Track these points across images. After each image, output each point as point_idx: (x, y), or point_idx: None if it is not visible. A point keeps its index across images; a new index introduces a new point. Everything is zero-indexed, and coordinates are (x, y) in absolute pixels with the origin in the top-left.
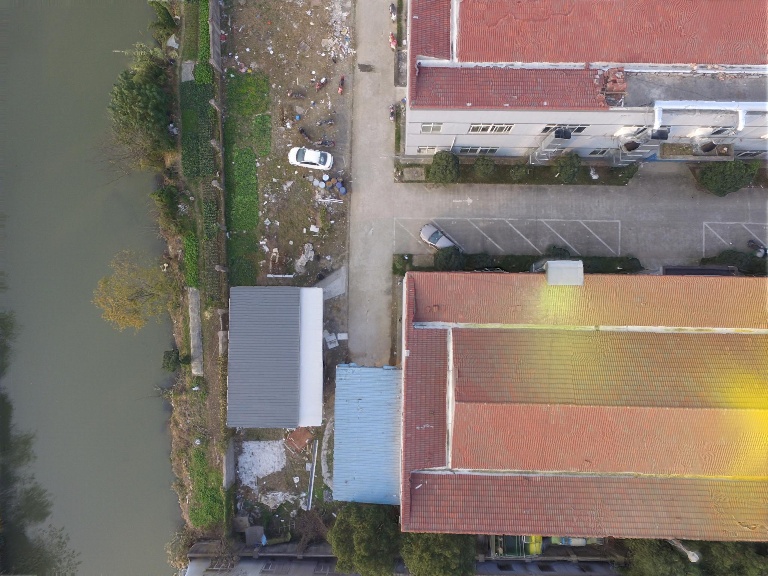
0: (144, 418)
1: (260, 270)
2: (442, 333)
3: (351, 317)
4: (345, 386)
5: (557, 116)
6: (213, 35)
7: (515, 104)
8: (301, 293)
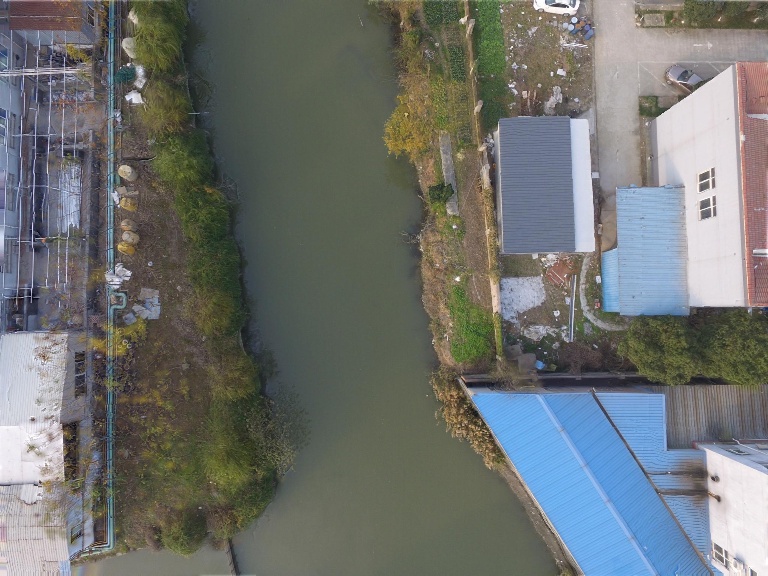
0: None
1: (510, 112)
2: (767, 124)
3: (601, 157)
4: (627, 206)
5: None
6: None
7: None
8: (570, 123)
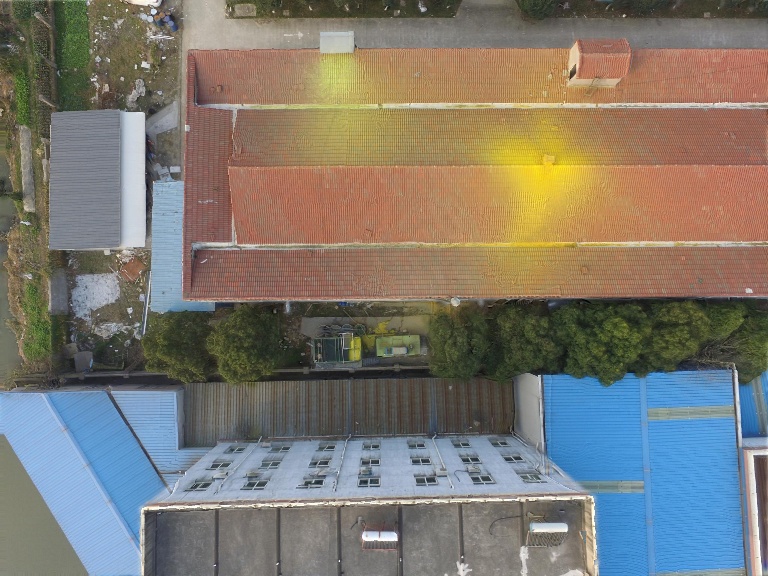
0: None
1: (91, 106)
2: (227, 113)
3: (183, 150)
4: (162, 200)
5: None
6: None
7: None
8: (122, 117)
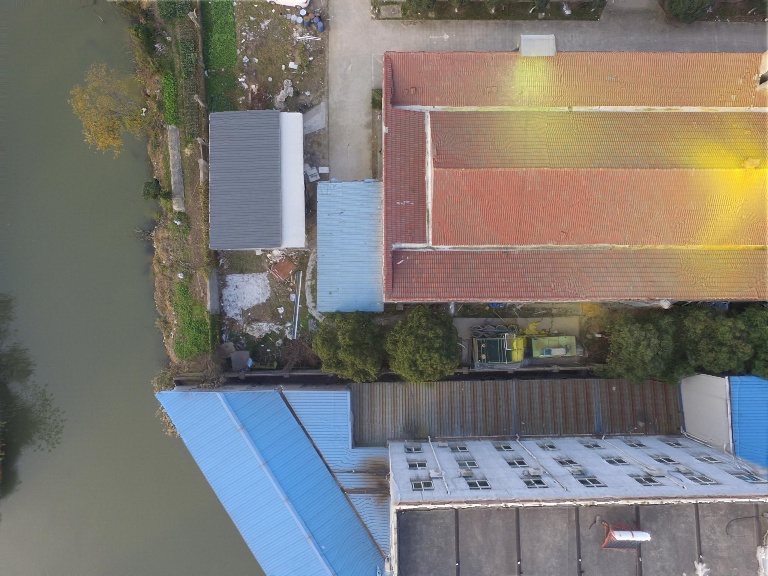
0: (126, 260)
1: (239, 107)
2: (420, 115)
3: (332, 151)
4: (327, 201)
5: None
6: None
7: None
8: (281, 117)
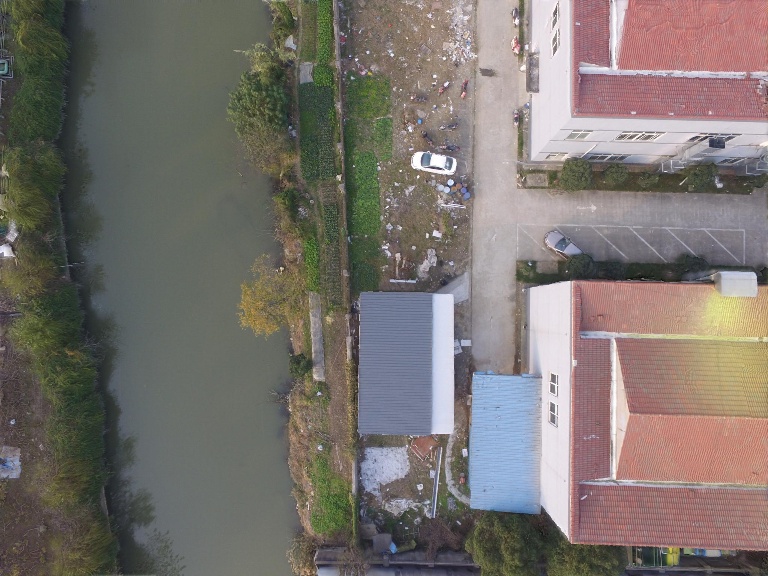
0: (260, 423)
1: (382, 275)
2: (606, 343)
3: (474, 323)
4: (482, 394)
5: (716, 125)
6: (337, 37)
7: (682, 113)
8: (433, 299)
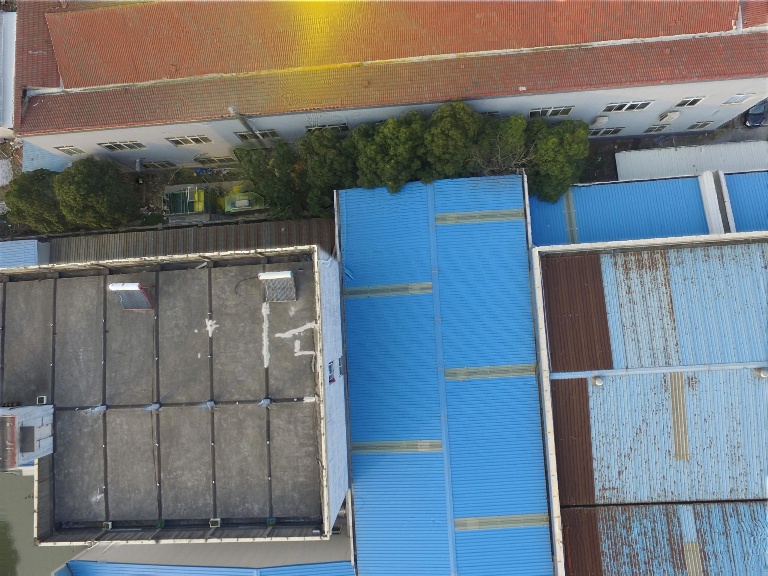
0: None
1: None
2: None
3: None
4: None
5: None
6: None
7: None
8: (5, 16)
